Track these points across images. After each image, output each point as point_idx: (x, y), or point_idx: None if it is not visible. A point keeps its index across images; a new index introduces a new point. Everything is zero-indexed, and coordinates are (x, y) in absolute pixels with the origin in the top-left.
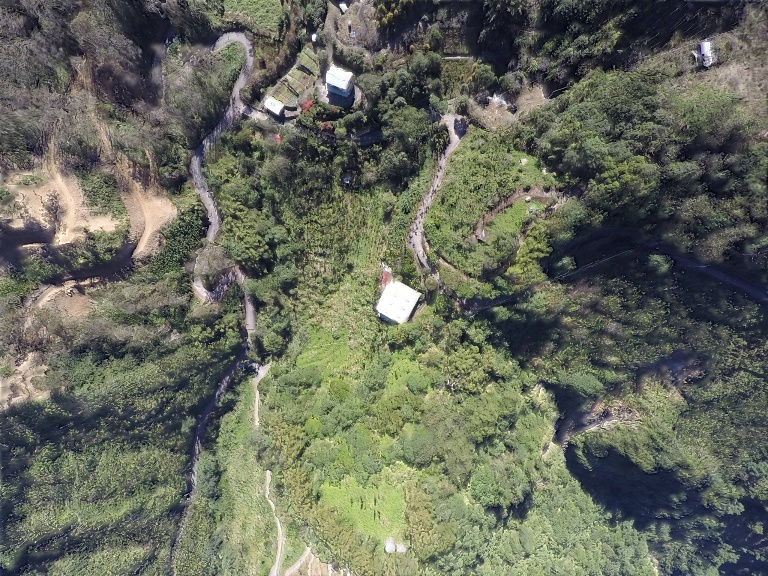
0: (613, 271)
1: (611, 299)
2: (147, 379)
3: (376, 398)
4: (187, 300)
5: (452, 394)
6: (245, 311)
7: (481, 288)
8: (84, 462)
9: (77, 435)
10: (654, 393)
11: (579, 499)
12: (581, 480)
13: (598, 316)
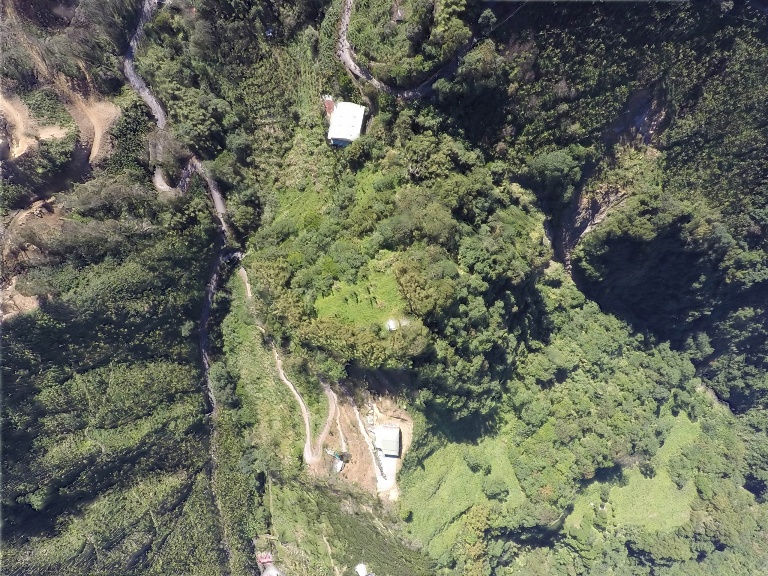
0: (536, 23)
1: (545, 54)
2: (132, 279)
3: (349, 214)
4: (153, 197)
5: (420, 185)
6: (213, 200)
7: (412, 62)
8: (93, 384)
9: (78, 351)
10: (627, 158)
11: (601, 319)
12: (598, 303)
13: (539, 79)
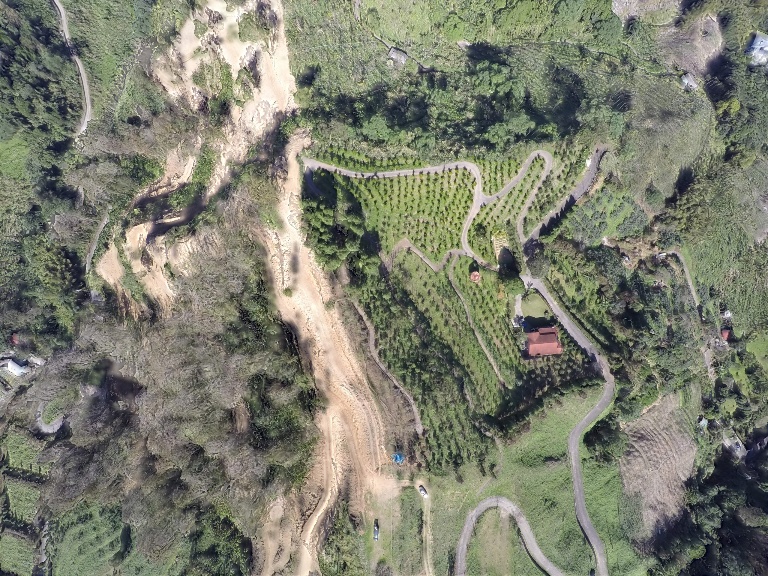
0: None
1: None
2: None
3: None
4: None
5: None
6: None
7: None
8: None
9: None
10: None
11: None
12: None
13: None
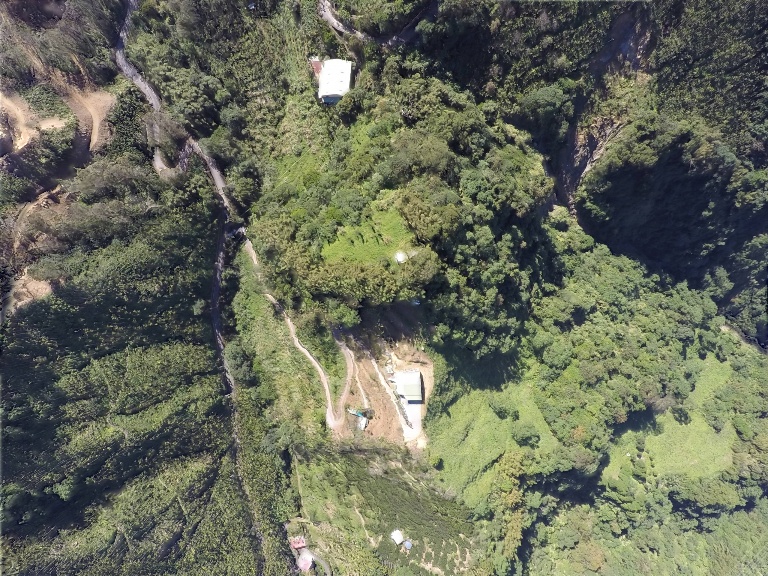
0: None
1: None
2: (140, 259)
3: (347, 165)
4: (154, 179)
5: (413, 128)
6: (212, 178)
7: (392, 7)
8: (111, 369)
9: (93, 335)
10: (618, 88)
11: (613, 260)
12: (608, 247)
13: (520, 14)
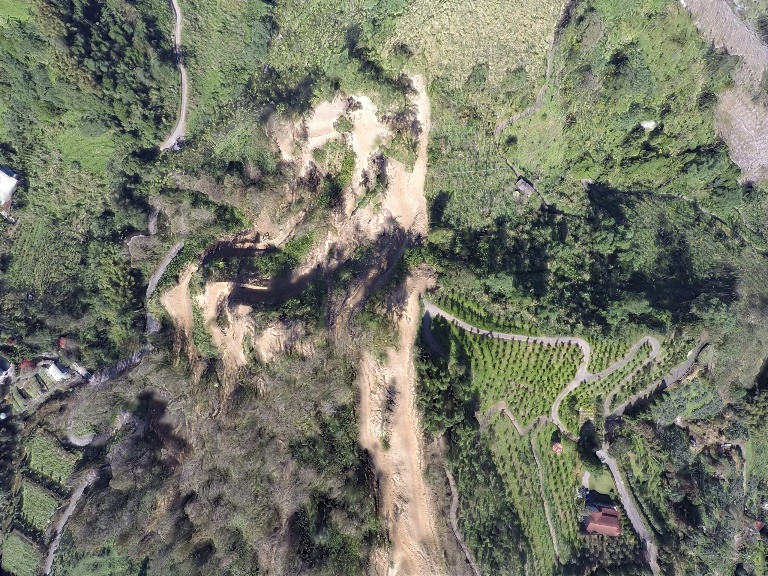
0: None
1: None
2: None
3: None
4: None
5: None
6: None
7: None
8: None
9: None
10: None
11: None
12: None
13: None
